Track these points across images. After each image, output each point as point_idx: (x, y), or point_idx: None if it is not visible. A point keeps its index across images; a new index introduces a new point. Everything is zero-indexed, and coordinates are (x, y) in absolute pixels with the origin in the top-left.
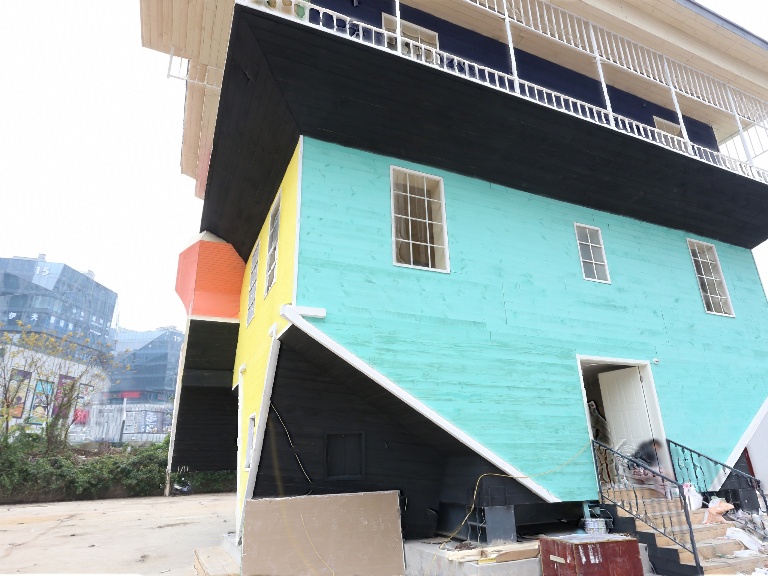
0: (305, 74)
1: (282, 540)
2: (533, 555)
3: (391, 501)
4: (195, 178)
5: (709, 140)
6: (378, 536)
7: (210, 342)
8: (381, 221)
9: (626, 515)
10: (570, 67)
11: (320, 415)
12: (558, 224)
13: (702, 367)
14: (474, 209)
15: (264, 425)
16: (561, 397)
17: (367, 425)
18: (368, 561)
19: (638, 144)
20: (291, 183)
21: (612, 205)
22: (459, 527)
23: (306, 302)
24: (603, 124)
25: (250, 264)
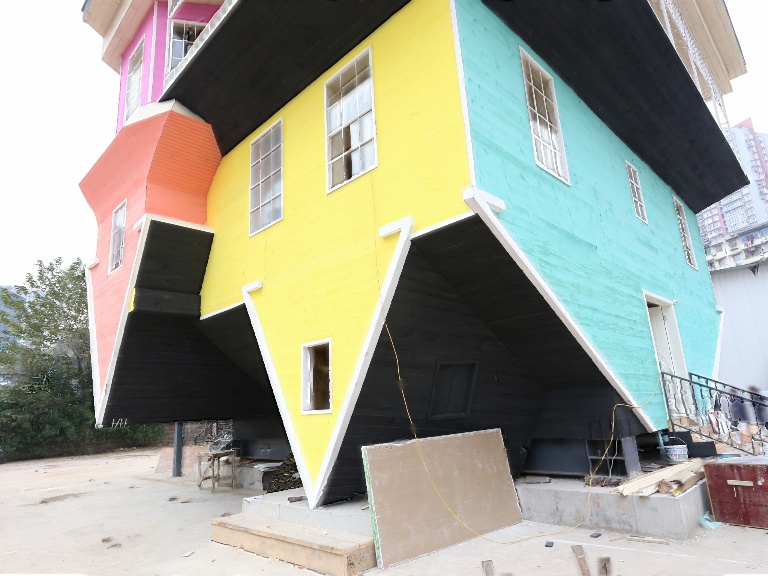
0: None
1: (412, 494)
2: (693, 482)
3: (497, 440)
4: (107, 33)
5: None
6: (494, 480)
7: (174, 254)
8: (521, 109)
9: (699, 440)
10: None
11: (437, 340)
12: (618, 157)
13: (692, 311)
14: (574, 121)
15: (372, 352)
16: (641, 329)
17: (482, 354)
18: (492, 509)
19: (690, 89)
20: (416, 35)
21: (644, 149)
22: (560, 463)
23: (483, 188)
24: None
25: (243, 155)
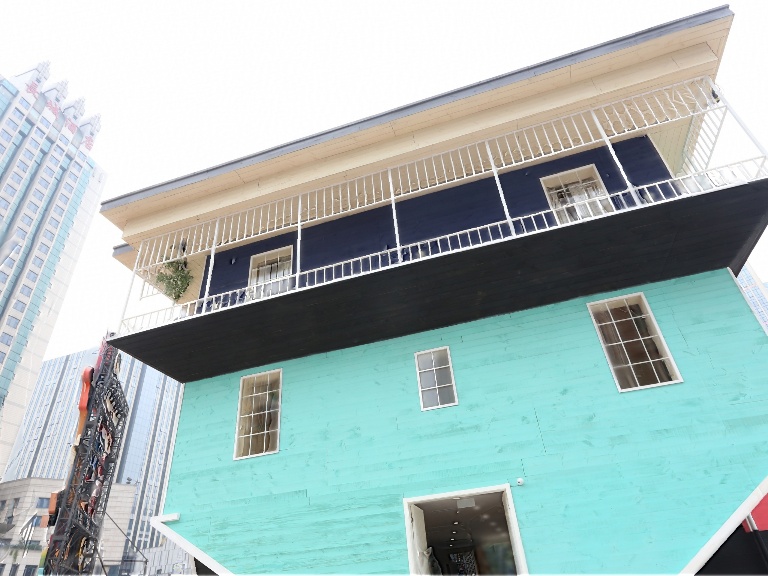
0: (160, 353)
1: None
2: None
3: None
4: None
5: (640, 155)
6: None
7: None
8: (229, 426)
9: None
10: (424, 193)
11: None
12: (396, 362)
13: (607, 472)
14: (308, 384)
15: None
16: (381, 550)
17: None
18: None
19: (429, 263)
20: None
21: (459, 316)
22: None
23: (169, 510)
24: (379, 269)
25: None
